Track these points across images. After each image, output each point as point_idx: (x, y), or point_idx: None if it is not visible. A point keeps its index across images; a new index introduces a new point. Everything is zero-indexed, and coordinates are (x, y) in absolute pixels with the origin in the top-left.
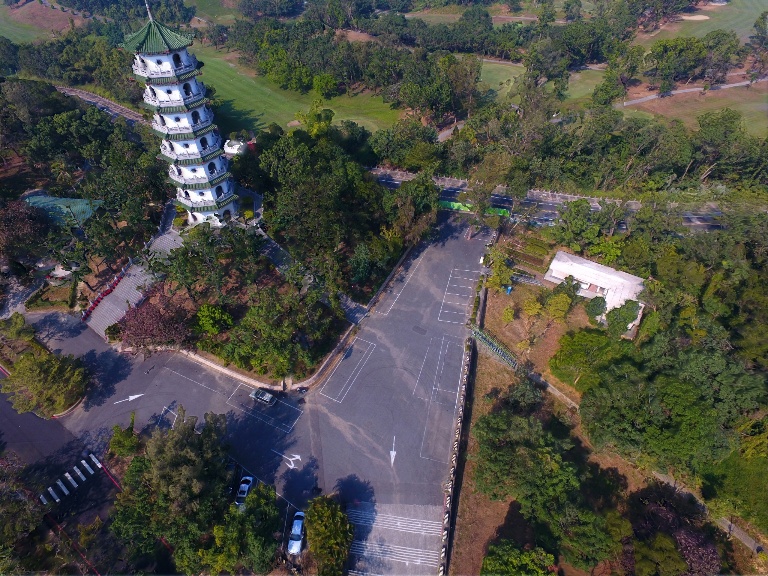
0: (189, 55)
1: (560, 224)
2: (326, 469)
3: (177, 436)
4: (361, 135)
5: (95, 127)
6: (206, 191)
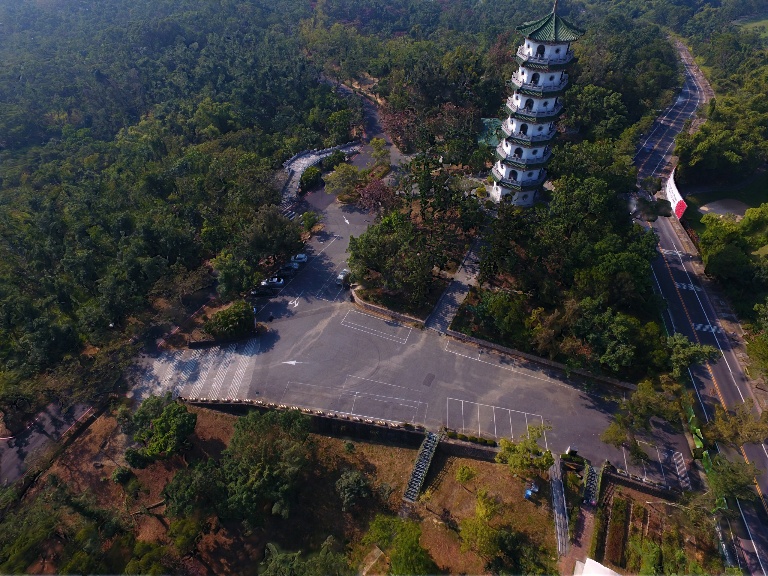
0: (561, 53)
1: (680, 567)
2: (286, 322)
3: (268, 211)
4: (766, 278)
5: (605, 109)
6: (504, 166)
